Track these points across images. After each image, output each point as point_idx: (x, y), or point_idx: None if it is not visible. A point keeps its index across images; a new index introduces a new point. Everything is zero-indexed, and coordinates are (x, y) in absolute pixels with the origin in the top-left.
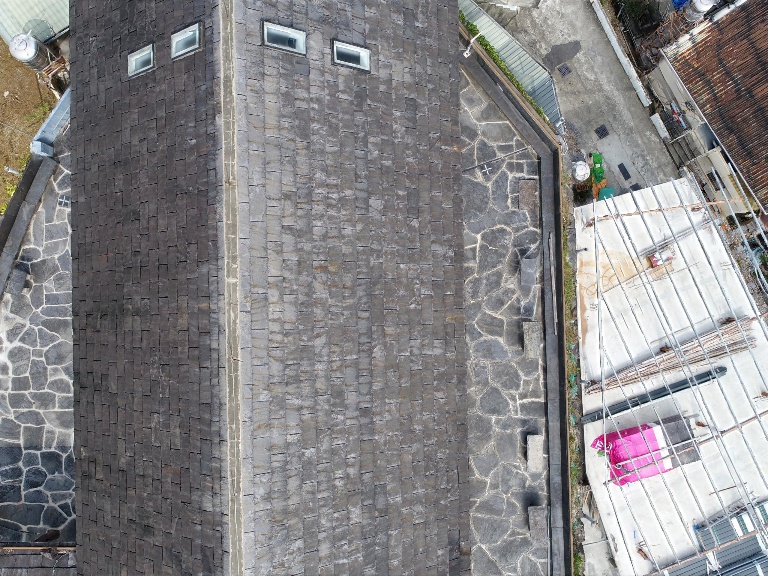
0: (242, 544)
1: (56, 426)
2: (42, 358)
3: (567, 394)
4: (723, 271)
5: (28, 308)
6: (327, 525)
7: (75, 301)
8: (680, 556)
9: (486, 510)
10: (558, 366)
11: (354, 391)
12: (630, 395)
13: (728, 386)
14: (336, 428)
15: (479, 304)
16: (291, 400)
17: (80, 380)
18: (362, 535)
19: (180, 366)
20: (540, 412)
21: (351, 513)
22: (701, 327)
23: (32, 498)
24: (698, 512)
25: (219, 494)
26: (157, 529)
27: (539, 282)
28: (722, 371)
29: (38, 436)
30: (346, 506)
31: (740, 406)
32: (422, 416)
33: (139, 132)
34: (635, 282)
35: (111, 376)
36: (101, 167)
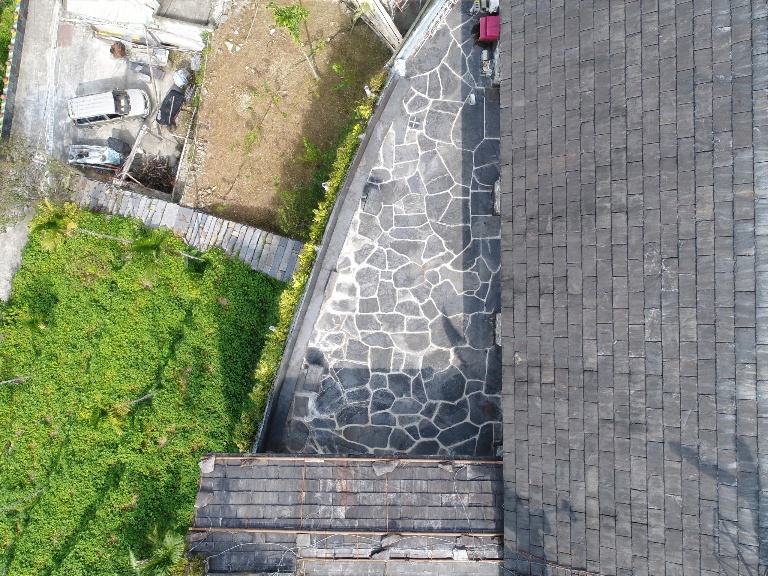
0: None
1: (404, 348)
2: (391, 280)
3: None
4: None
5: (377, 229)
6: None
7: (506, 207)
8: None
9: None
10: None
11: None
12: None
13: None
14: None
15: None
16: None
17: (515, 286)
18: None
19: (699, 257)
20: None
21: None
22: None
23: (379, 420)
24: None
25: None
26: (654, 425)
27: None
28: None
29: (386, 358)
30: None
31: None
32: None
33: (627, 27)
34: None
35: (572, 277)
36: (556, 68)
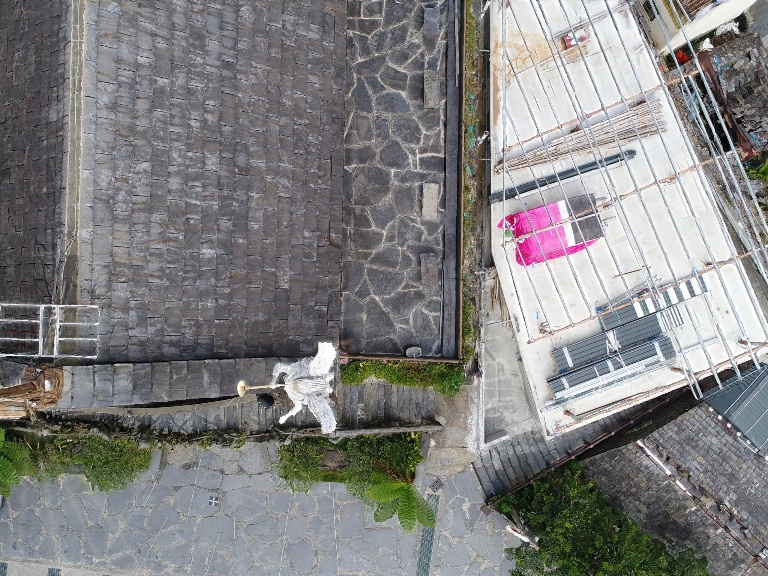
0: (81, 143)
1: None
2: None
3: (463, 140)
4: (637, 55)
5: None
6: (179, 161)
7: None
8: (581, 337)
9: (381, 262)
10: (458, 118)
11: (217, 41)
12: (539, 176)
13: (637, 170)
14: (194, 69)
15: (383, 57)
16: (144, 23)
17: None
18: (219, 185)
19: None
20: (439, 167)
21: (207, 159)
22: (612, 111)
23: None
24: (601, 294)
25: (62, 99)
26: (13, 166)
27: (444, 38)
28: (631, 153)
29: None
30: (202, 150)
31: (648, 190)
32: (293, 93)
33: None
34: (549, 64)
35: None
36: None
